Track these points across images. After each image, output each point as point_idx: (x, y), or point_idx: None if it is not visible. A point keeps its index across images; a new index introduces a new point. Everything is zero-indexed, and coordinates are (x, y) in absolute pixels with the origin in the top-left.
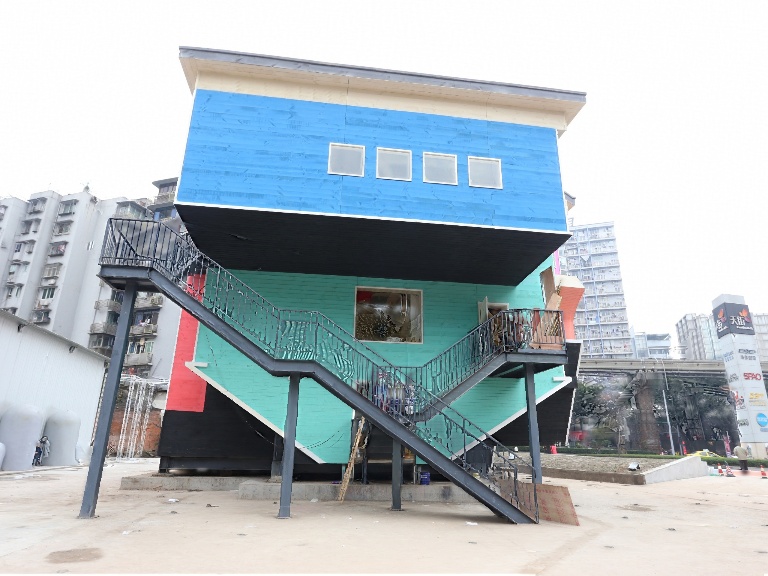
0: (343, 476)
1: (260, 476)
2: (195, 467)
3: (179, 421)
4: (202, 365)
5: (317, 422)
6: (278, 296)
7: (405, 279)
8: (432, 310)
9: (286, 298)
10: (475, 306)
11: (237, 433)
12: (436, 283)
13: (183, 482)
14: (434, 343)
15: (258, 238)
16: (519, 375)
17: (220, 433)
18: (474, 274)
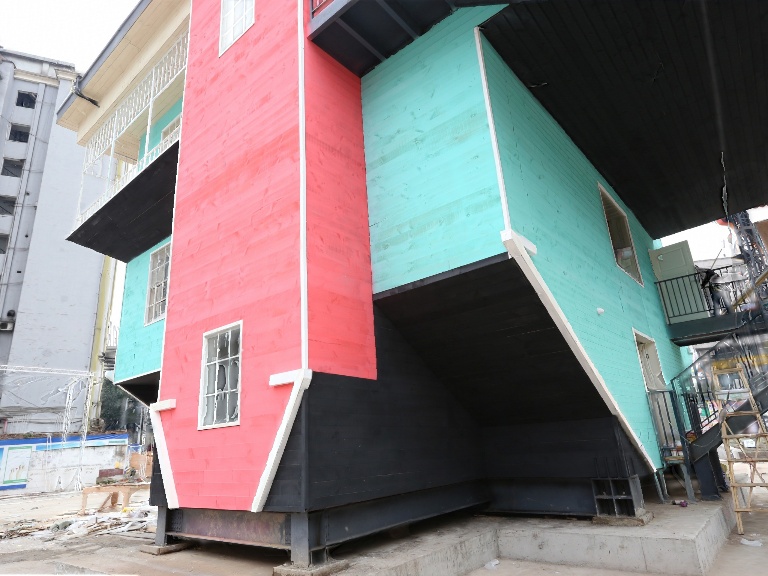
0: (661, 491)
1: (469, 521)
2: (371, 527)
3: (339, 403)
4: (532, 248)
5: (631, 396)
6: (555, 152)
7: (618, 193)
8: (636, 245)
9: (561, 161)
10: (648, 252)
11: (434, 430)
12: (629, 211)
13: (408, 574)
14: (647, 289)
15: (700, 2)
16: (693, 342)
17: (411, 431)
18: (671, 210)
